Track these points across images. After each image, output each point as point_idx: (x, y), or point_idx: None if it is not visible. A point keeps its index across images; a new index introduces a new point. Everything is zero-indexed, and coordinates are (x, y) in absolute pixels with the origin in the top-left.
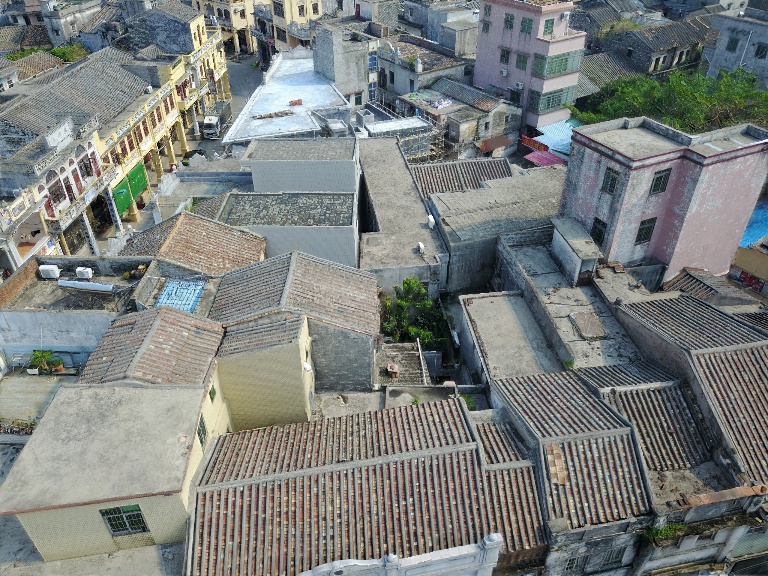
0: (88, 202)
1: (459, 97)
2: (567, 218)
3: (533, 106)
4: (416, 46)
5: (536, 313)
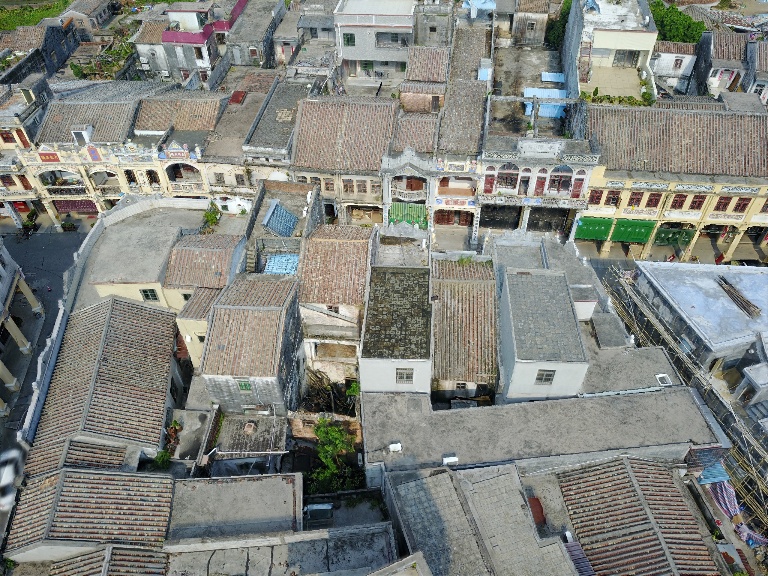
0: (526, 204)
1: None
2: None
3: None
4: None
5: None
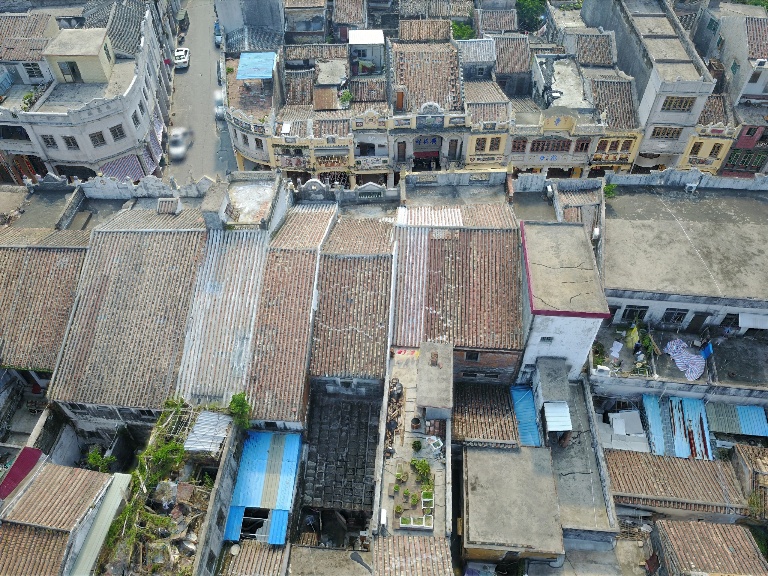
0: None
1: None
2: None
3: None
4: None
5: (50, 4)
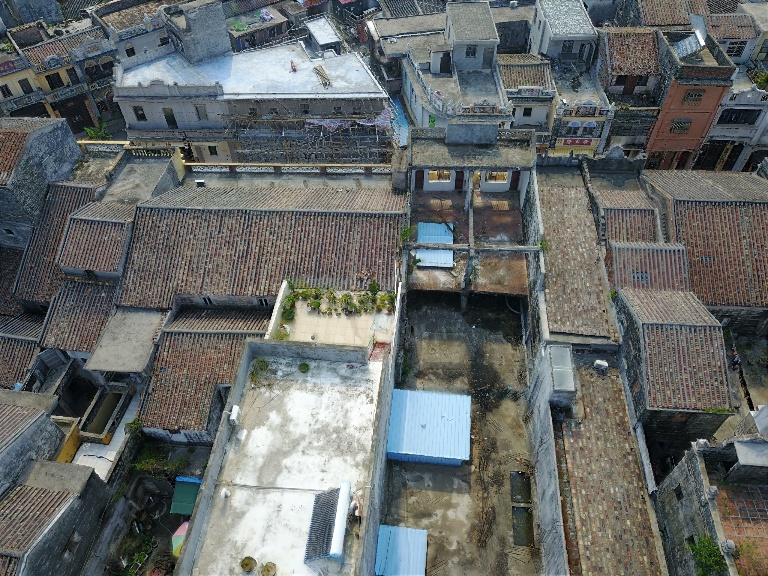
0: None
1: (253, 7)
2: None
3: None
4: (128, 9)
5: None
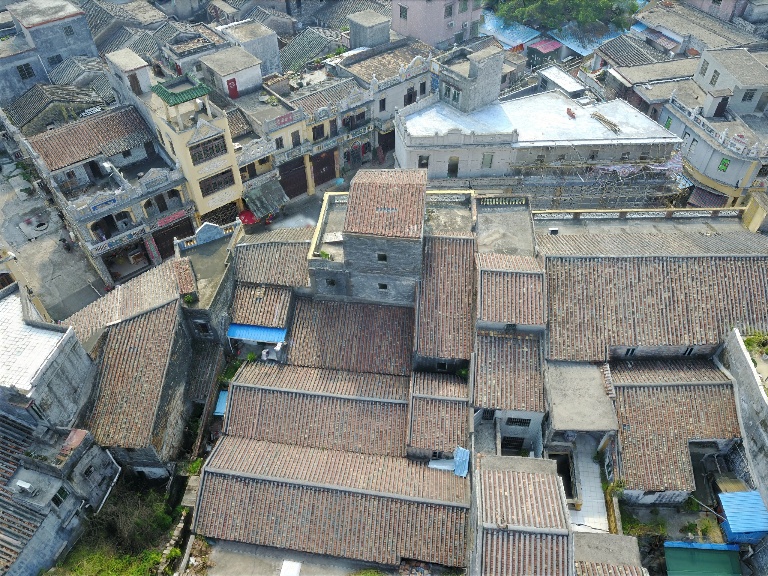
0: None
1: None
2: (752, 1)
3: (474, 34)
4: (366, 61)
5: None
